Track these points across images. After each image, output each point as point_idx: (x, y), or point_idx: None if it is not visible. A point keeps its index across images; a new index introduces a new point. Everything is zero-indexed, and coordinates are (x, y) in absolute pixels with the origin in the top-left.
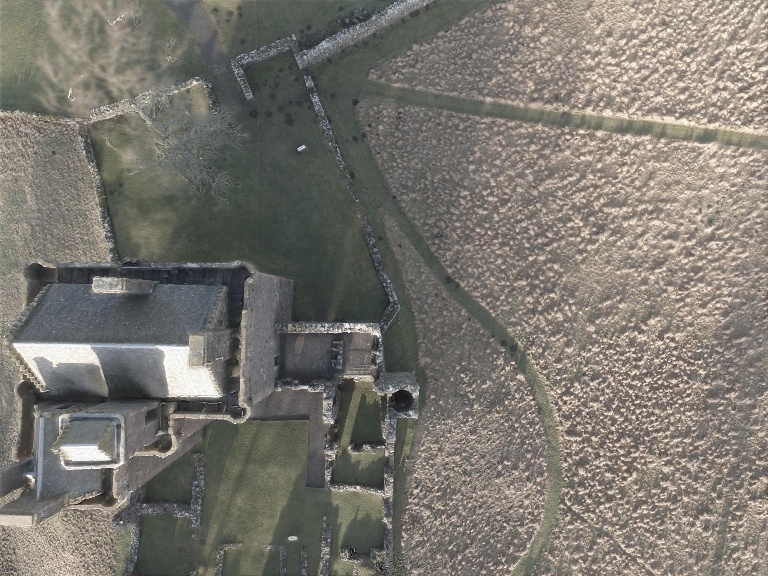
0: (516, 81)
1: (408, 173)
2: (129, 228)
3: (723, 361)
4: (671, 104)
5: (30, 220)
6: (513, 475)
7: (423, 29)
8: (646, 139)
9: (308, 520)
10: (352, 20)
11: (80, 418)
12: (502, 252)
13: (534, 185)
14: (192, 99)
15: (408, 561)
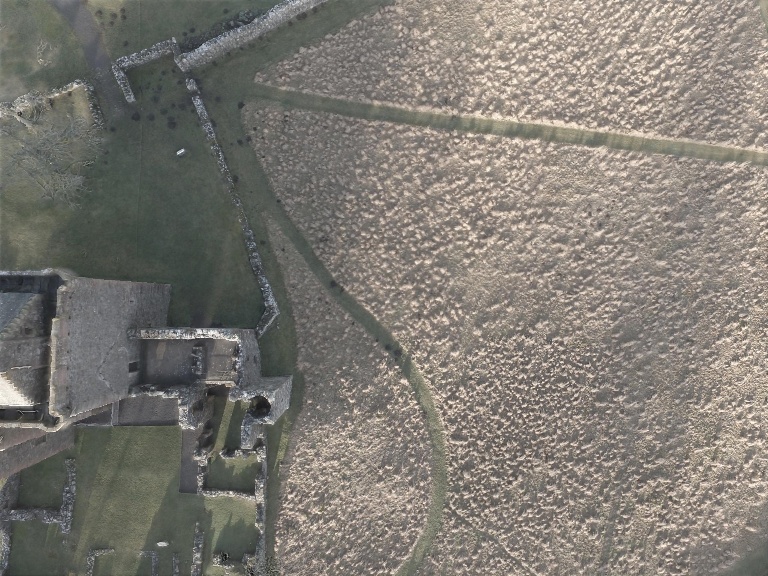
0: (405, 84)
1: (293, 177)
2: (7, 232)
3: (612, 365)
4: (561, 108)
5: None
6: (395, 479)
7: (311, 32)
8: (535, 143)
9: (181, 526)
10: (237, 23)
11: None
12: (388, 256)
13: (422, 189)
14: (74, 102)
15: (281, 566)
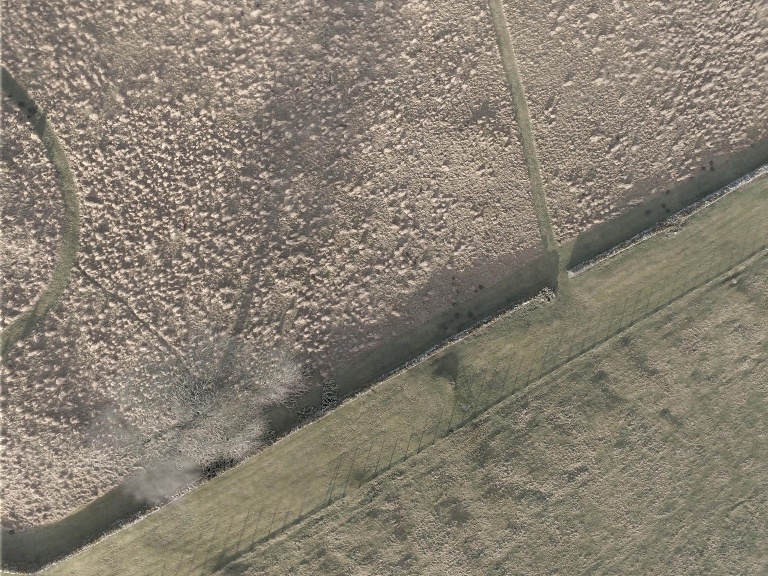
0: None
1: None
2: None
3: (261, 143)
4: None
5: None
6: (15, 230)
7: None
8: None
9: None
10: None
11: None
12: (30, 17)
13: None
14: None
15: None
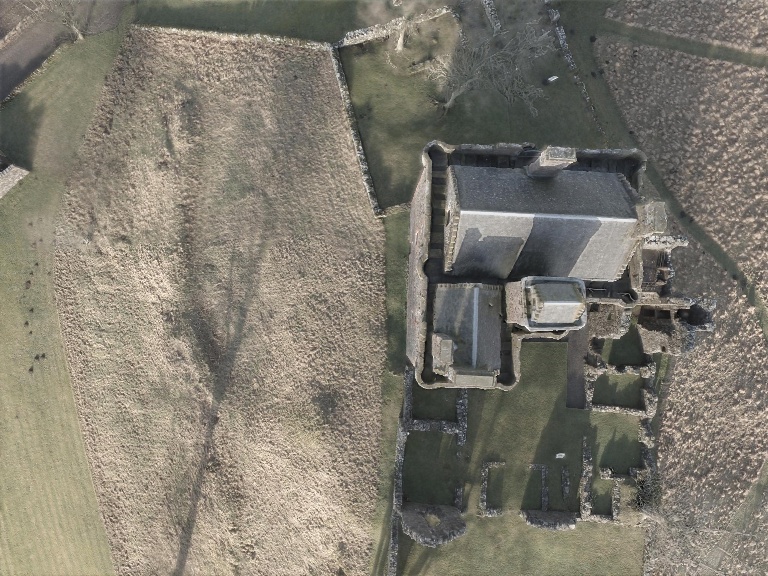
0: (741, 26)
1: (644, 110)
2: (381, 152)
3: None
4: None
5: (271, 143)
6: (747, 403)
7: None
8: None
9: (569, 440)
10: None
11: (542, 281)
12: (732, 189)
13: (759, 127)
14: (439, 28)
15: (663, 481)
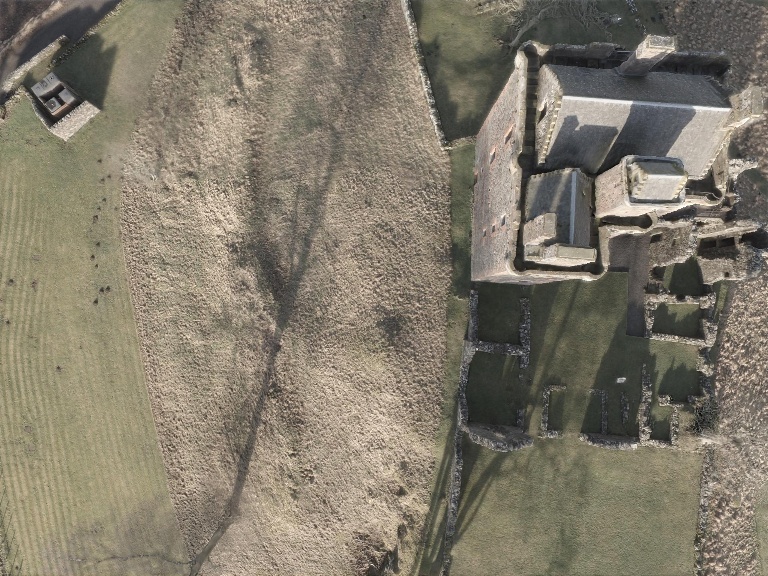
0: None
1: None
2: (447, 87)
3: None
4: None
5: (339, 80)
6: None
7: None
8: None
9: (628, 367)
10: None
11: (642, 160)
12: None
13: None
14: None
15: (721, 410)
